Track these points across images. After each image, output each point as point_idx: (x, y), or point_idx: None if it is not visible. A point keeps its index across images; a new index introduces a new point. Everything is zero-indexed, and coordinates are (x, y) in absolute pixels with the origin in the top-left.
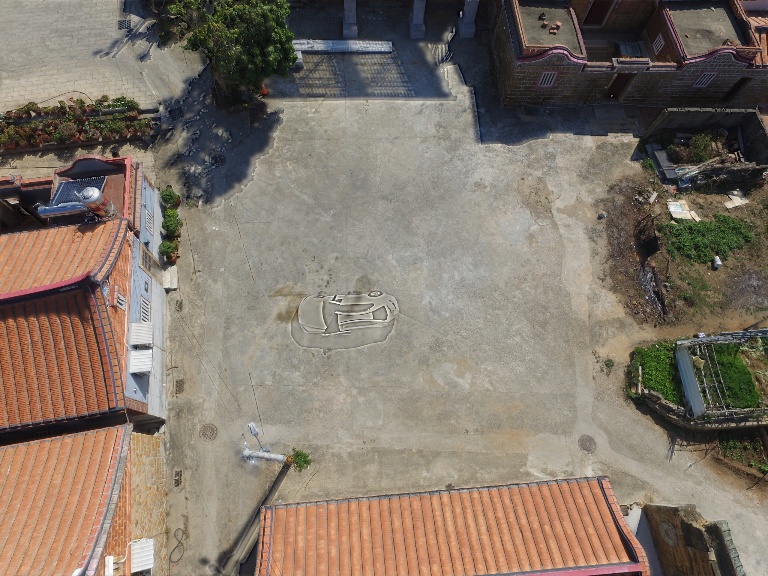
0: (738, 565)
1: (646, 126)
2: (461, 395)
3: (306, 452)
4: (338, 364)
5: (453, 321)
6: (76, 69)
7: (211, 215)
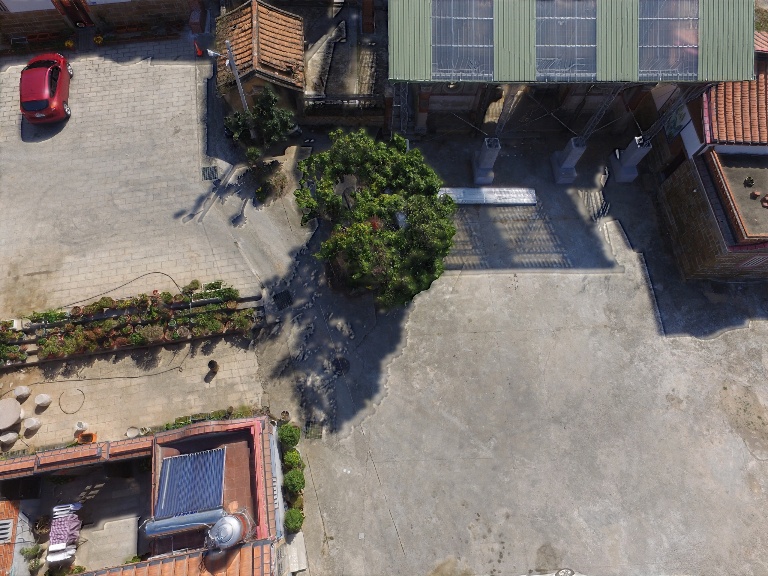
0: None
1: None
2: None
3: None
4: None
5: None
6: (155, 239)
7: (339, 450)
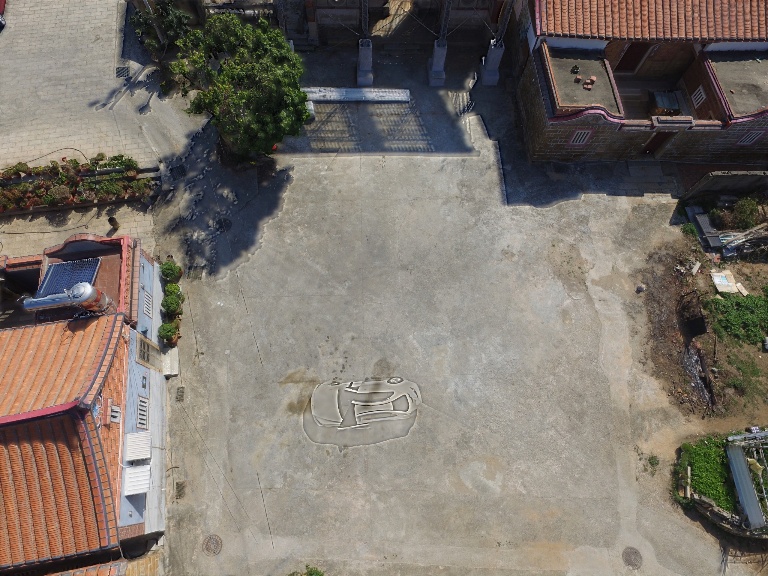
0: None
1: (685, 185)
2: (492, 500)
3: (321, 569)
4: (355, 463)
5: (481, 412)
6: (70, 123)
7: (215, 288)
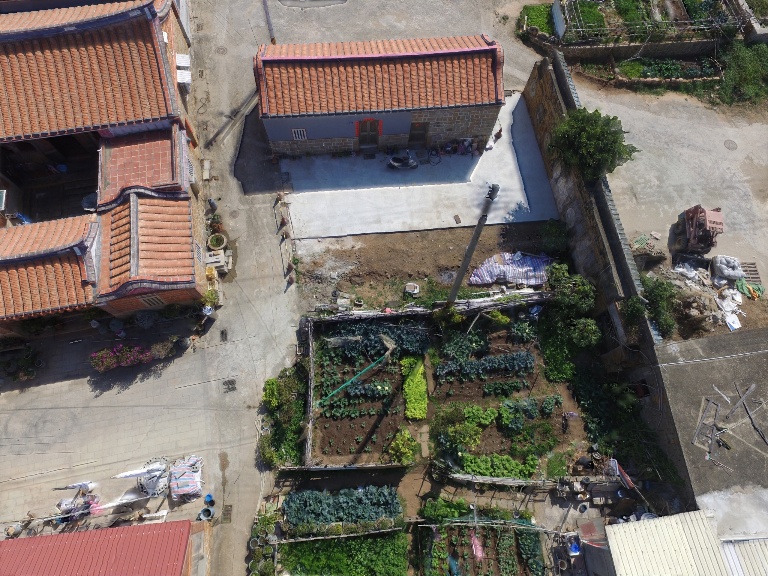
0: (566, 69)
1: None
2: (398, 31)
3: None
4: (312, 15)
5: None
6: None
7: None
